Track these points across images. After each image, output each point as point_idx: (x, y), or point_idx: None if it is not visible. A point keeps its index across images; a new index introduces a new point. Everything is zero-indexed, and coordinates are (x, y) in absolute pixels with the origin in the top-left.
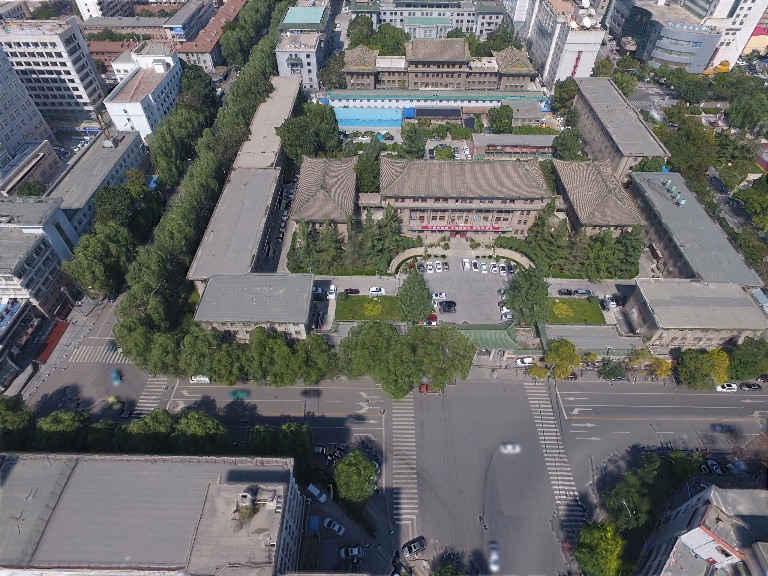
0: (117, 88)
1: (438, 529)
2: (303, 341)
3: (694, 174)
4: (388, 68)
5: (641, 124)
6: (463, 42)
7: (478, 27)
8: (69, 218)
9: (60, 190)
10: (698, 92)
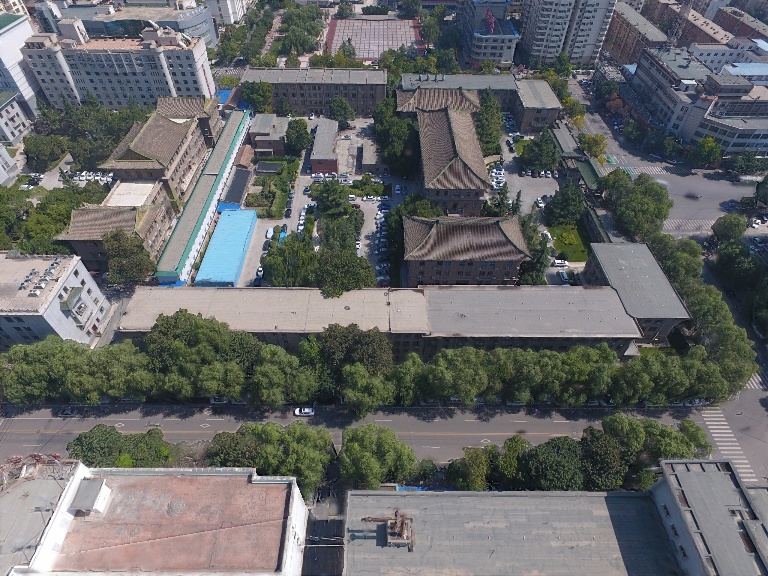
0: (201, 574)
1: (715, 213)
2: (670, 241)
3: (390, 73)
4: (149, 197)
5: (337, 71)
6: (158, 115)
7: (5, 131)
8: (636, 501)
9: (569, 569)
10: (257, 50)
